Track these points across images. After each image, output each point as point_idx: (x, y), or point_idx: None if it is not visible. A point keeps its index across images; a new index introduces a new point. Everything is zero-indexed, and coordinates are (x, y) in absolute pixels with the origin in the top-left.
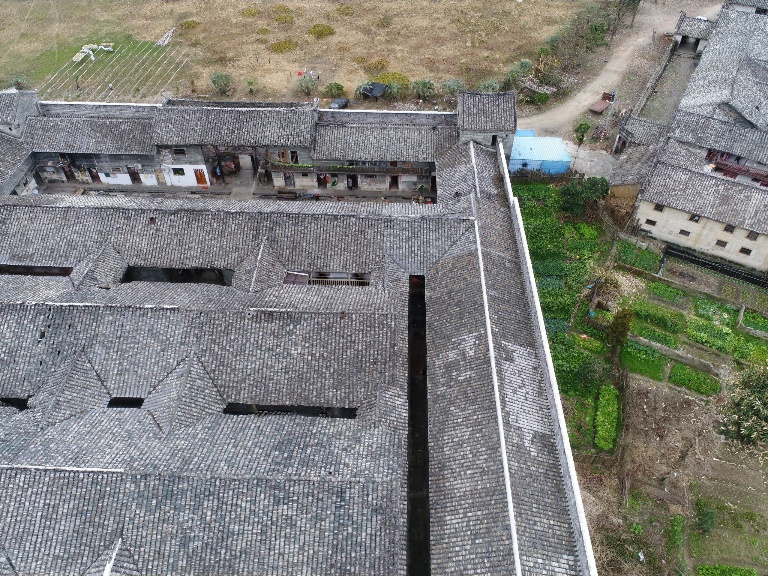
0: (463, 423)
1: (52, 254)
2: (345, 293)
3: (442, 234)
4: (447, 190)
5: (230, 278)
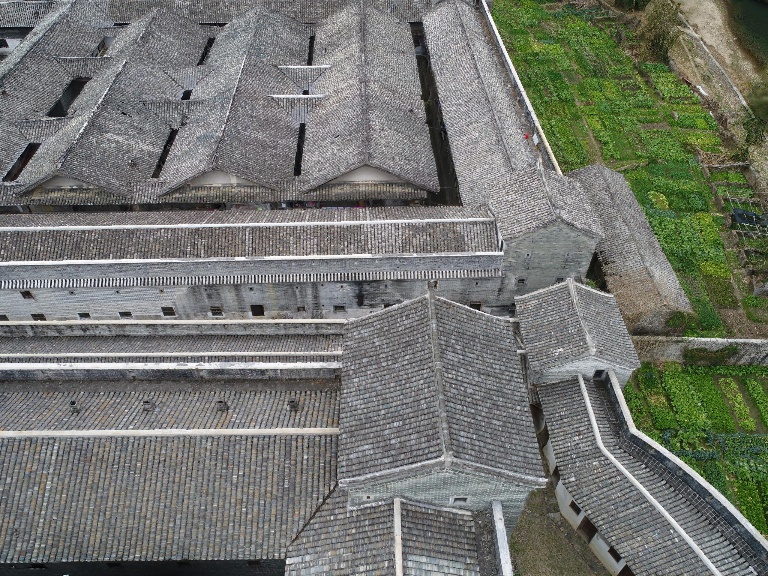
0: (228, 8)
1: (8, 151)
2: (125, 34)
3: (88, 6)
4: (25, 20)
5: (64, 105)
